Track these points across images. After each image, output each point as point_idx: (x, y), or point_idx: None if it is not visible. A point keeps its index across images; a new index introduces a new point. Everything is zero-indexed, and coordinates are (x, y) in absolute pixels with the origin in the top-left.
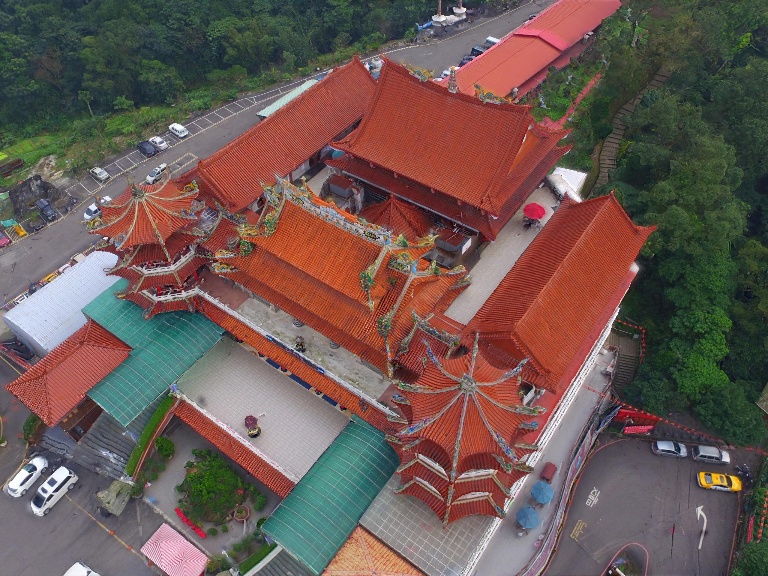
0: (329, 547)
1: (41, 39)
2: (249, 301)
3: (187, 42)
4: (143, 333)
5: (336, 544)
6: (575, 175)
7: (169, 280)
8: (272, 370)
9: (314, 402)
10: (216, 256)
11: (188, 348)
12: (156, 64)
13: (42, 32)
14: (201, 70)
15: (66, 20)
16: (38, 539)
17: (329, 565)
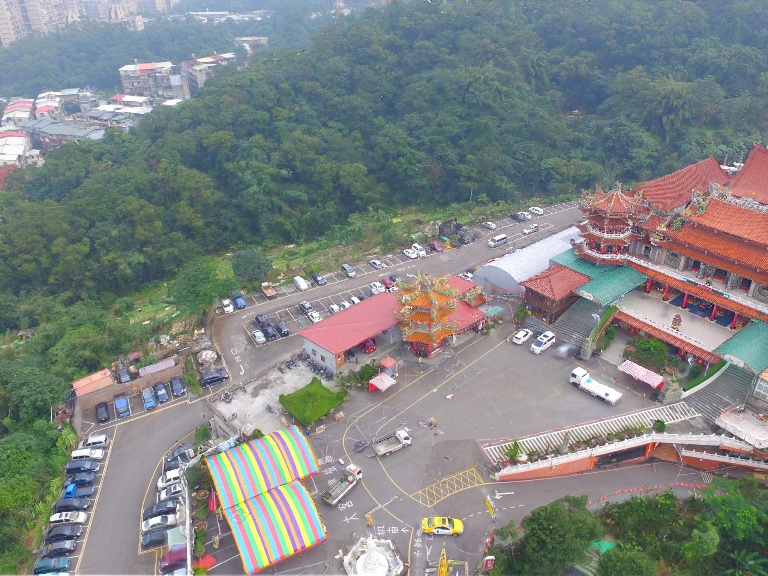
0: (761, 364)
1: (435, 155)
2: (661, 266)
3: (526, 169)
4: (595, 272)
5: (764, 365)
6: None
7: (620, 241)
8: (674, 307)
9: (710, 324)
10: (657, 228)
11: (629, 280)
12: (505, 179)
13: (436, 152)
14: (526, 190)
15: (448, 148)
16: (539, 363)
17: (762, 373)
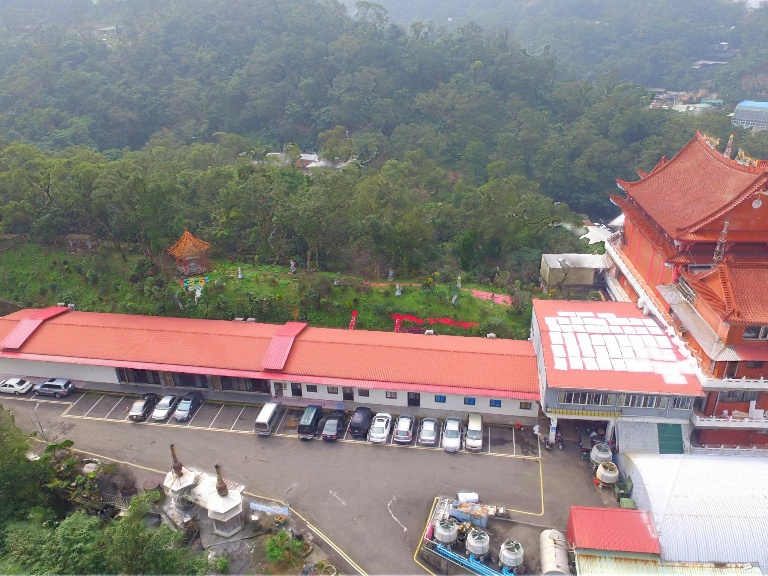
0: None
1: None
2: None
3: None
4: None
5: None
6: (552, 258)
7: None
8: None
9: None
10: None
11: None
12: None
13: None
14: None
15: None
16: None
17: None
